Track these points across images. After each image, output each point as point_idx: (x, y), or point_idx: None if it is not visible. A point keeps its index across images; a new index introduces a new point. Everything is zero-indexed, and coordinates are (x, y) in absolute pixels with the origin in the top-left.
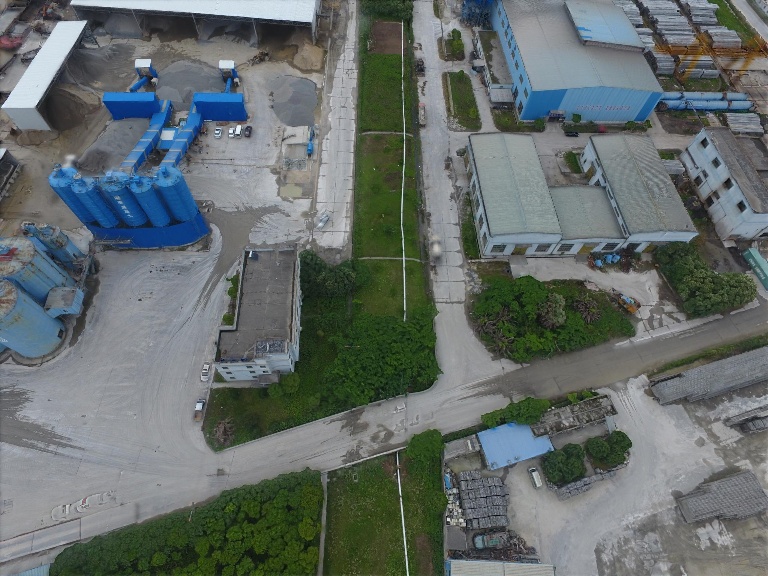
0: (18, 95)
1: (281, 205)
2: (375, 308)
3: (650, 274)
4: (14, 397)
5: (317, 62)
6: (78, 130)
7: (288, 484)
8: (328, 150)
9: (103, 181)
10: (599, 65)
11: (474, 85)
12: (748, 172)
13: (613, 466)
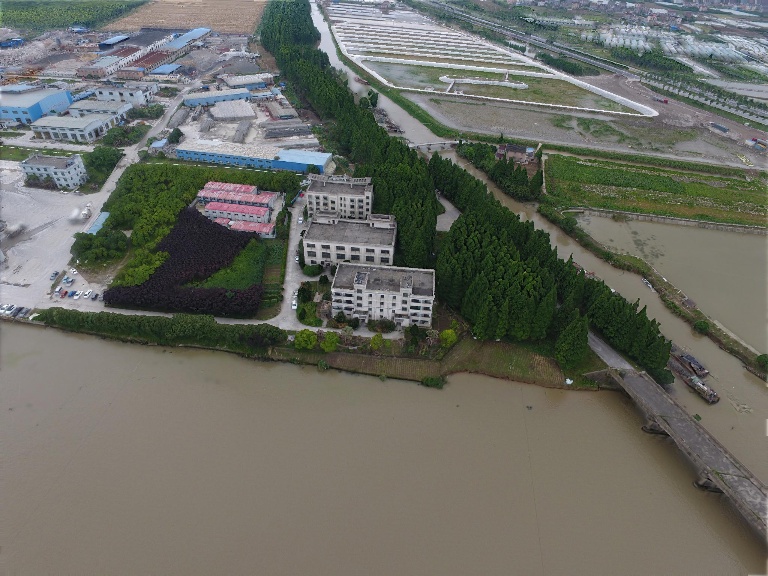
0: None
1: None
2: None
3: (136, 120)
4: None
5: None
6: None
7: None
8: None
9: None
10: (36, 94)
11: None
12: (121, 89)
13: (182, 135)
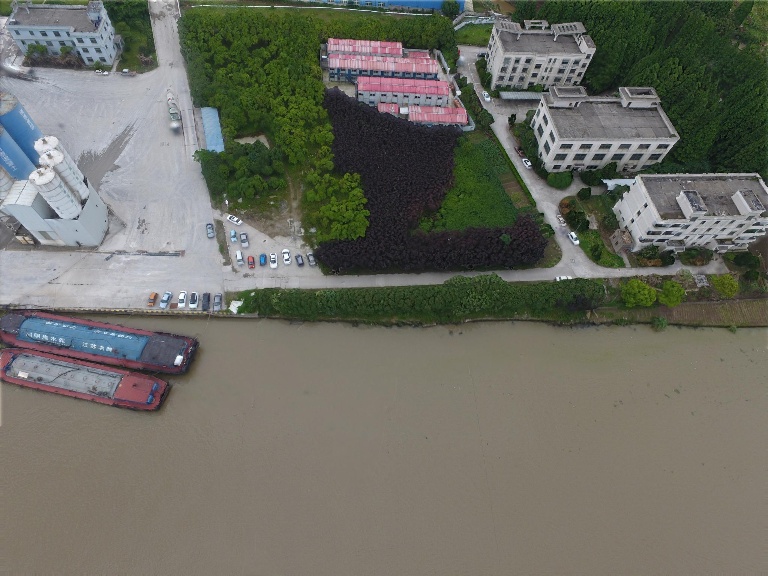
0: None
1: None
2: None
3: None
4: (84, 159)
5: None
6: None
7: (182, 24)
8: None
9: None
10: None
11: None
12: None
13: None
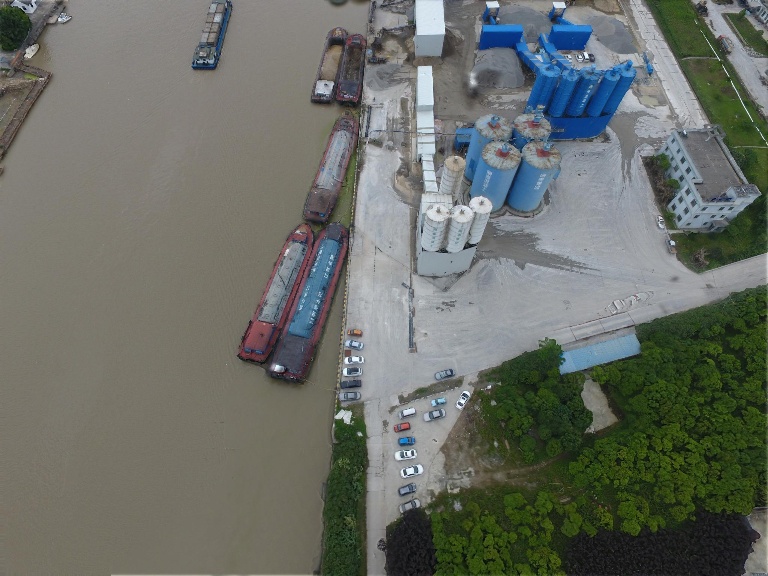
0: (424, 26)
1: (647, 110)
2: (766, 181)
3: None
4: (527, 237)
5: (616, 6)
6: (455, 57)
7: None
8: (661, 71)
9: (584, 72)
10: None
11: (752, 23)
12: None
13: None
